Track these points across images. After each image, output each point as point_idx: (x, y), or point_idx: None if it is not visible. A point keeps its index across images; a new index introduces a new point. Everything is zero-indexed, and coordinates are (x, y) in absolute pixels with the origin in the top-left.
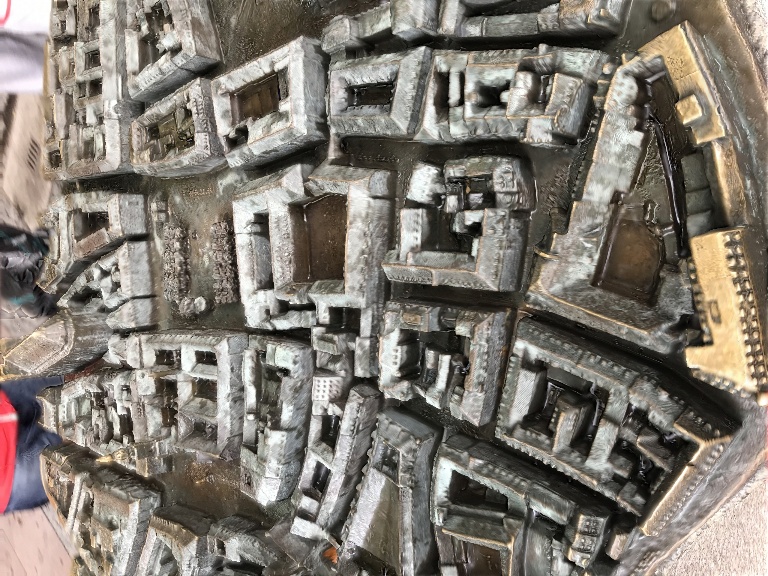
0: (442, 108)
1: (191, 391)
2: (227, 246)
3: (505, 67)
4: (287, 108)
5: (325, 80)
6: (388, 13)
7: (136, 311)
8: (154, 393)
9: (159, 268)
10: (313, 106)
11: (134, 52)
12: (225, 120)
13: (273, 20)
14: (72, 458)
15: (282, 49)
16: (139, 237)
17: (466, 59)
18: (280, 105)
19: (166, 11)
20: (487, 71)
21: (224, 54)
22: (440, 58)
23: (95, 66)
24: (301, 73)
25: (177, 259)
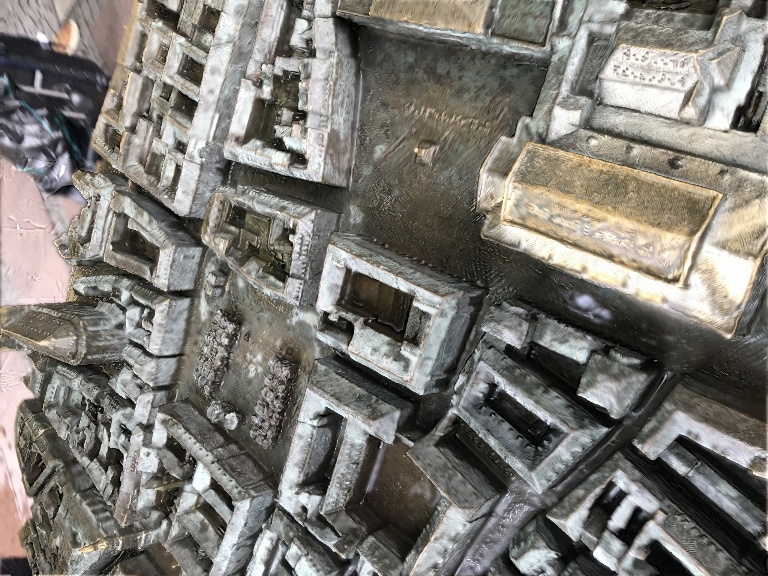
0: (596, 508)
1: (194, 502)
2: (282, 394)
3: (699, 568)
4: (411, 358)
5: (466, 331)
6: (579, 344)
7: (158, 370)
8: (154, 473)
9: (196, 330)
10: (441, 363)
11: (245, 112)
12: (330, 295)
13: (429, 196)
14: (49, 432)
15: (433, 295)
16: (184, 292)
17: (654, 507)
18: (404, 349)
19: (302, 102)
20: (674, 547)
21: (353, 179)
22: (623, 476)
23: (191, 75)
24: (444, 331)
25: (220, 353)
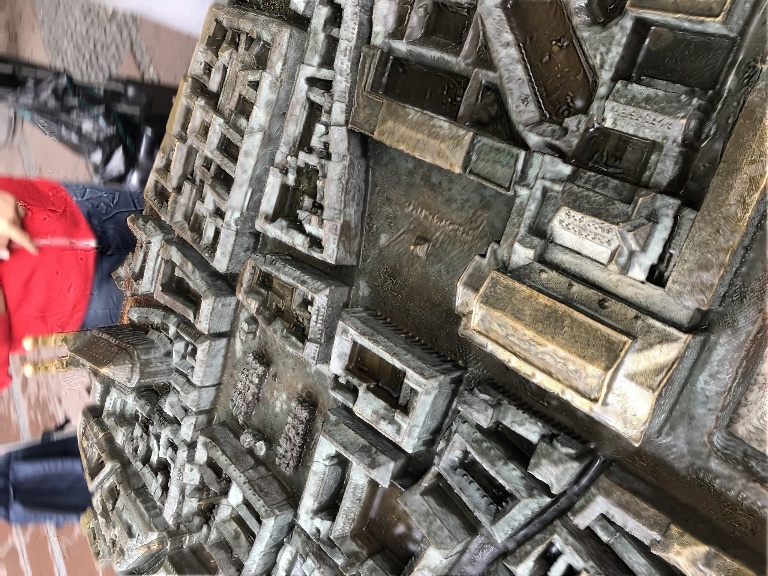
0: (540, 559)
1: (230, 513)
2: (302, 432)
3: None
4: (402, 424)
5: (448, 402)
6: (533, 428)
7: (200, 398)
8: (197, 484)
9: (232, 365)
10: (427, 428)
11: (273, 194)
12: (340, 361)
13: (423, 283)
14: (108, 435)
15: (419, 377)
16: (222, 333)
17: (580, 567)
18: (397, 416)
19: (320, 195)
20: None
21: (362, 258)
22: (559, 539)
23: (228, 151)
24: (428, 405)
25: (252, 390)
